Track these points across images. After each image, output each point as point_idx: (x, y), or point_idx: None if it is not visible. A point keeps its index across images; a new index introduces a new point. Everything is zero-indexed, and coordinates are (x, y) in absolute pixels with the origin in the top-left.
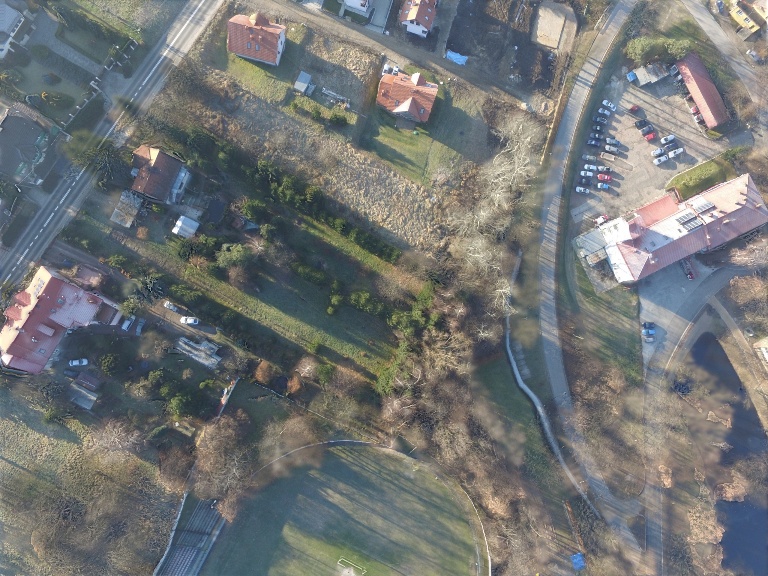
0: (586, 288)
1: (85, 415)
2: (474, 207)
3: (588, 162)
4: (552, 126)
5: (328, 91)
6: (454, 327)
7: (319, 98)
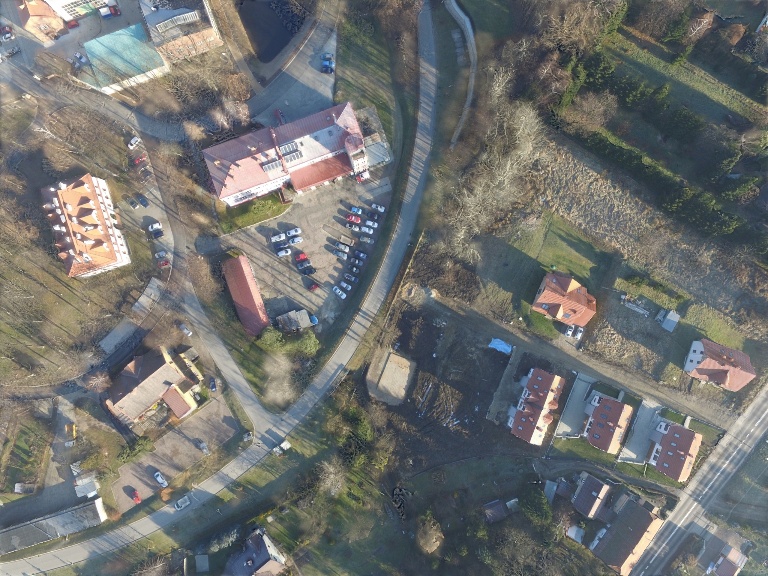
0: (385, 113)
1: None
2: (499, 191)
3: (369, 236)
4: (407, 270)
5: (643, 313)
6: (555, 55)
7: (652, 307)
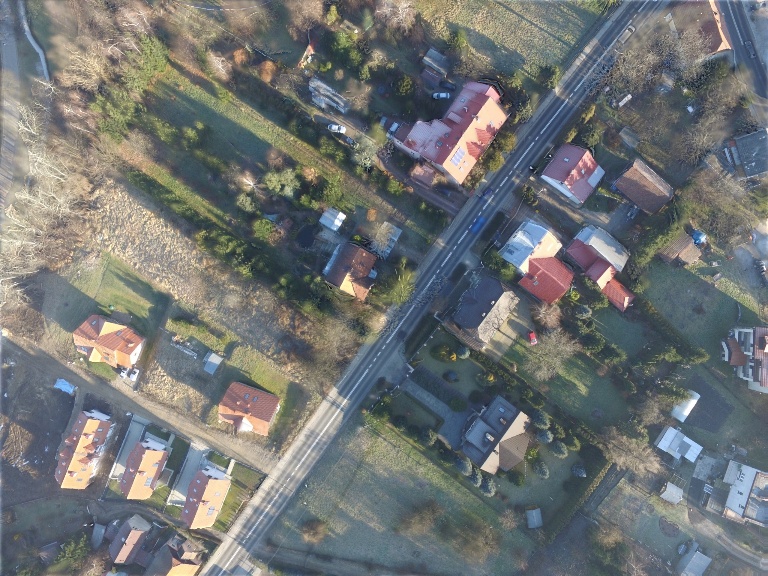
0: None
1: (440, 48)
2: (64, 229)
3: None
4: None
5: (191, 354)
6: (75, 94)
7: (201, 348)
